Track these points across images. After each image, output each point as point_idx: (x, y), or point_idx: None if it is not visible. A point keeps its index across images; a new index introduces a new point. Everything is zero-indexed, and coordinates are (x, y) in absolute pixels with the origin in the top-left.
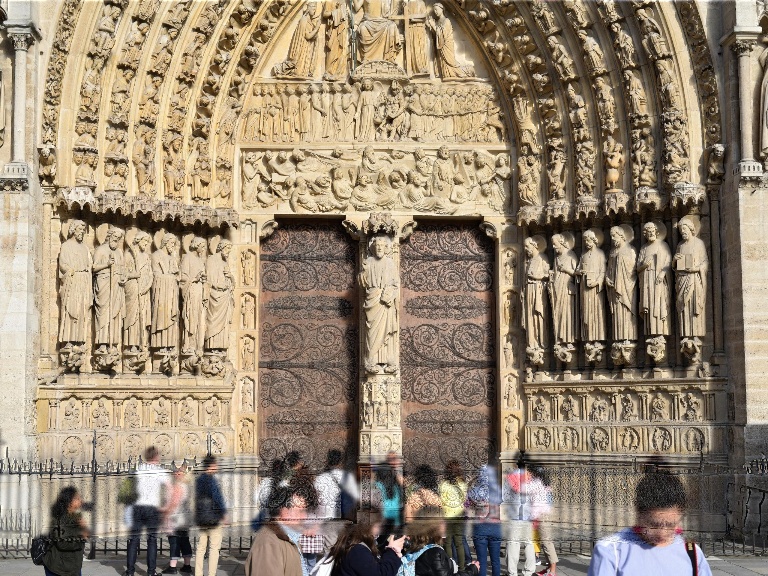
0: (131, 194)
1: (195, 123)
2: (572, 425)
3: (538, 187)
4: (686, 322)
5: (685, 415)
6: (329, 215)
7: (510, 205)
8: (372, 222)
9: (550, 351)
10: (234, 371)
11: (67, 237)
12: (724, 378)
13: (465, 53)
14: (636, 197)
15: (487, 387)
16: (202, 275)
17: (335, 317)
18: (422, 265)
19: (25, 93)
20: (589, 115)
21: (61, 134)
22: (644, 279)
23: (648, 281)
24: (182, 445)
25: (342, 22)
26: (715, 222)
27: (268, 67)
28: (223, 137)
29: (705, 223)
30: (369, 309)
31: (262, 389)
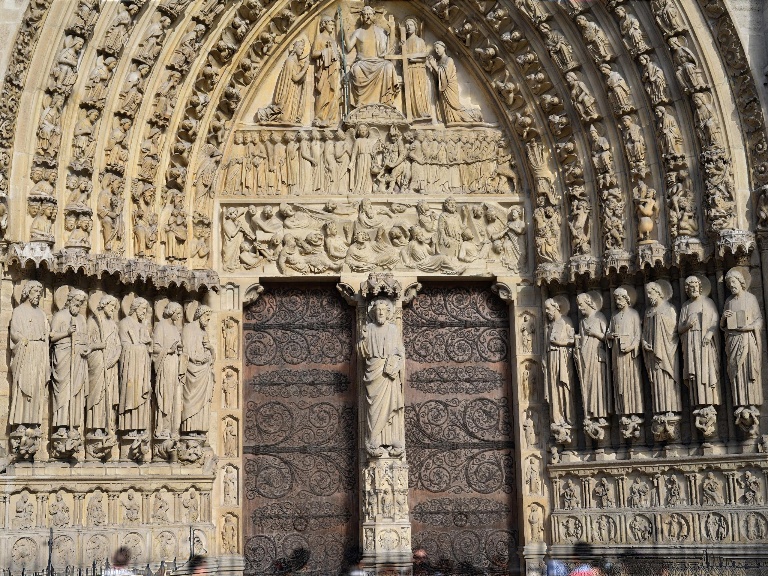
0: (95, 252)
1: (169, 173)
2: (607, 512)
3: (558, 241)
4: (740, 389)
5: (743, 497)
6: (321, 277)
7: (525, 263)
8: (372, 283)
9: (578, 428)
10: (215, 457)
11: (20, 301)
12: None
13: (470, 96)
14: (675, 248)
15: (505, 471)
16: (178, 346)
17: (330, 394)
18: (427, 333)
19: None
20: (615, 159)
21: (14, 181)
22: (688, 341)
23: (693, 343)
24: (155, 545)
25: (333, 62)
26: (767, 274)
27: (250, 113)
28: (201, 189)
29: (755, 276)
30: (370, 383)
31: (247, 478)
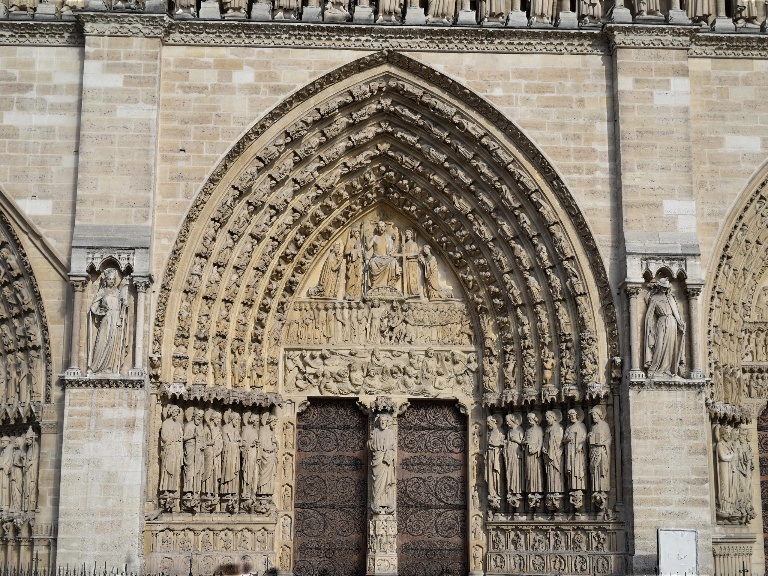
0: (209, 386)
1: (253, 333)
2: (520, 553)
3: (497, 379)
4: (596, 481)
5: (596, 547)
6: (347, 397)
7: (478, 391)
8: (378, 404)
9: (505, 498)
10: (277, 510)
11: (166, 417)
12: (622, 521)
13: (446, 280)
14: (562, 391)
15: (460, 524)
16: (257, 442)
17: (350, 471)
18: (414, 433)
19: (144, 321)
20: (532, 330)
21: (164, 346)
22: (568, 449)
23: (571, 451)
24: (240, 564)
25: (358, 258)
26: (617, 410)
27: (305, 290)
28: (272, 342)
29: (610, 410)
30: (375, 467)
31: (296, 523)
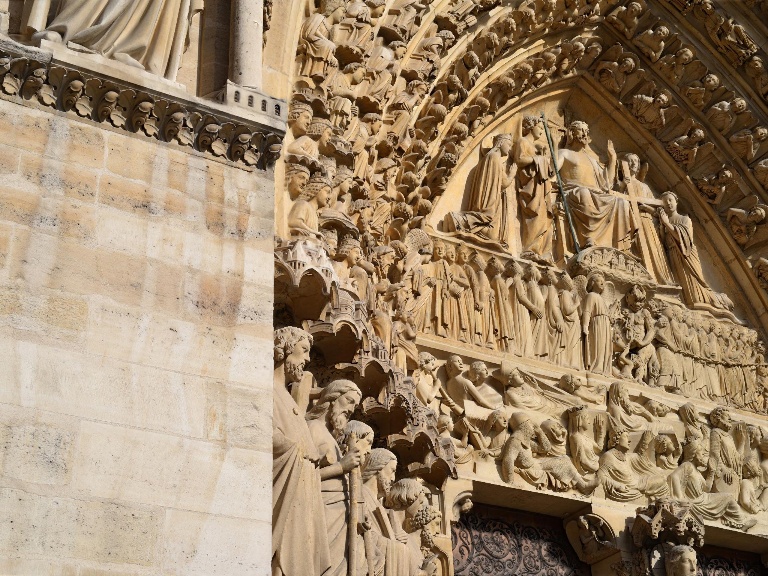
0: None
1: None
2: None
3: None
4: None
5: None
6: (559, 500)
7: None
8: None
9: None
10: None
11: None
12: None
13: None
14: None
15: None
16: None
17: None
18: None
19: None
20: None
21: None
22: None
23: None
24: None
25: (548, 177)
26: None
27: (433, 218)
28: None
29: None
30: None
31: None
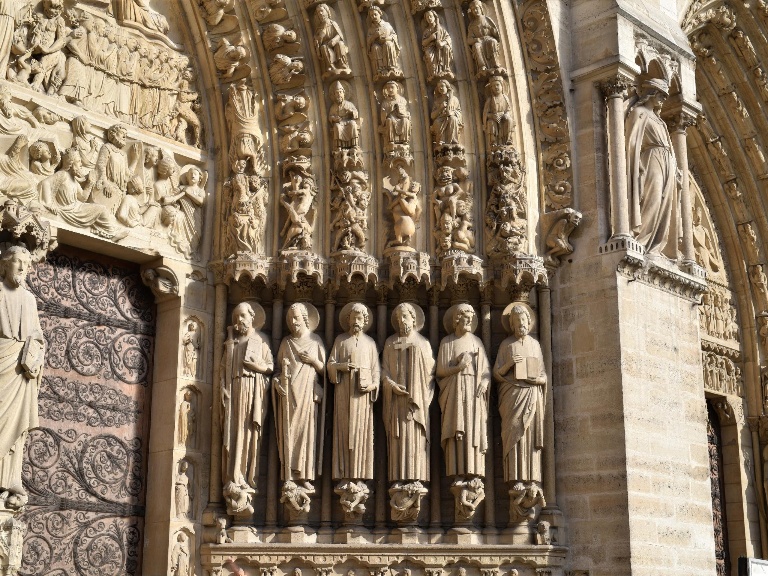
0: None
1: None
2: None
3: (263, 226)
4: (523, 458)
5: None
6: None
7: (197, 249)
8: (13, 216)
9: None
10: None
11: None
12: (565, 548)
13: None
14: (453, 262)
15: (127, 551)
16: None
17: None
18: (44, 320)
19: None
20: (363, 134)
21: None
22: (458, 387)
23: (464, 391)
24: None
25: None
26: (548, 318)
27: None
28: None
29: None
30: None
31: None
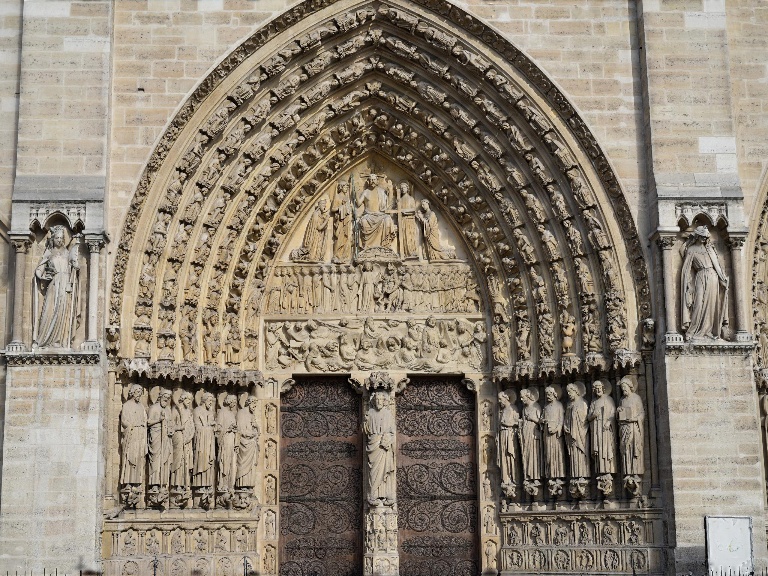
0: (178, 362)
1: (228, 302)
2: (540, 548)
3: (509, 350)
4: (628, 463)
5: (630, 539)
6: (337, 374)
7: (486, 364)
8: (373, 380)
9: (521, 486)
10: (259, 505)
11: (127, 398)
12: (660, 509)
13: (448, 239)
14: (586, 360)
15: (470, 516)
16: (234, 426)
17: (343, 458)
18: (414, 414)
19: (98, 286)
20: (548, 292)
21: (124, 316)
22: (594, 427)
23: (597, 429)
24: (217, 568)
25: (347, 216)
26: (649, 381)
27: (287, 253)
28: (251, 312)
29: (642, 381)
30: (371, 452)
31: (282, 520)
